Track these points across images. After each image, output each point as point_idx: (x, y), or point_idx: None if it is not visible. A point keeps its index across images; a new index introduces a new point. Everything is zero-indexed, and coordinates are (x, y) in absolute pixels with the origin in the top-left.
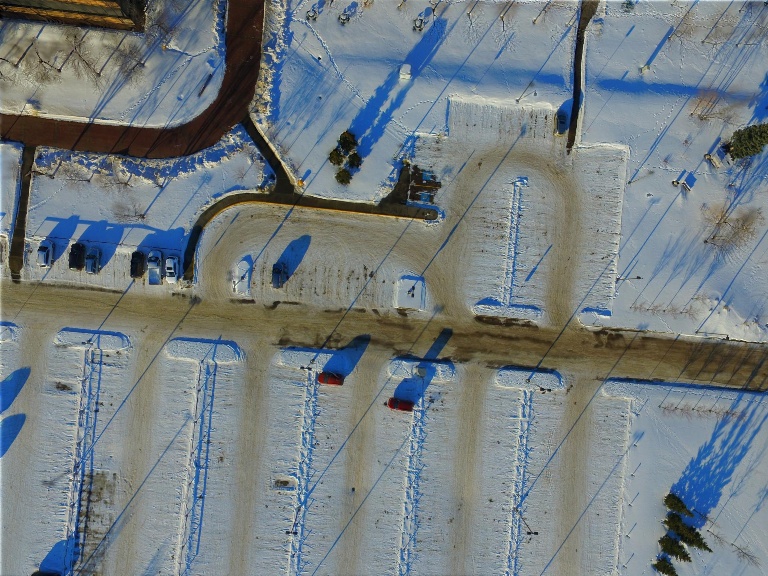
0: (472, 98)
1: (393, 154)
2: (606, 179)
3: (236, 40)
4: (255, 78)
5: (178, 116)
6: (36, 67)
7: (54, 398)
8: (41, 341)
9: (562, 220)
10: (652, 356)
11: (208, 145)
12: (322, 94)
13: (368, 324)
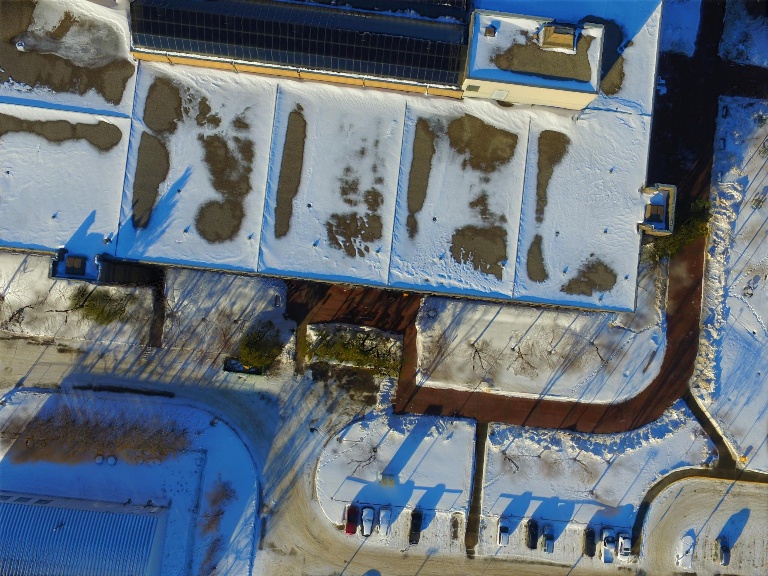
0: None
1: None
2: None
3: (676, 316)
4: (695, 353)
5: (624, 392)
6: (515, 360)
7: None
8: None
9: None
10: None
11: (651, 420)
12: (761, 370)
13: None
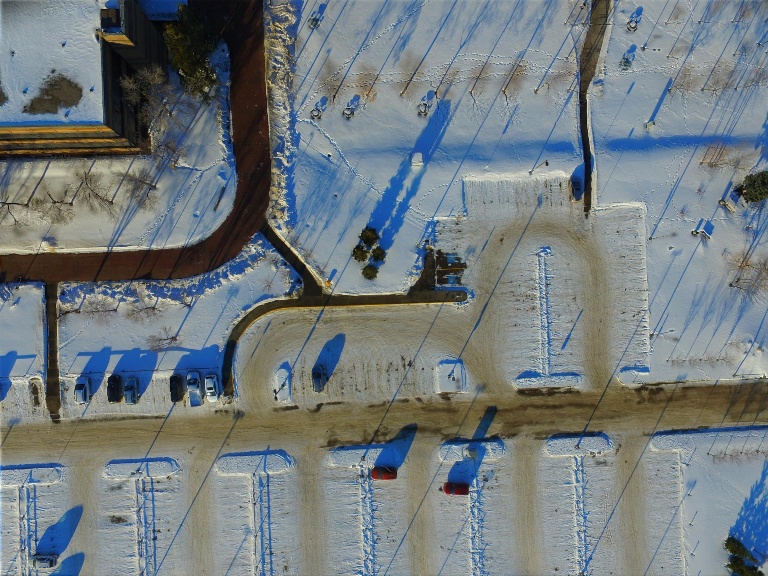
0: (486, 176)
1: (415, 242)
2: (627, 238)
3: (244, 149)
4: (268, 184)
5: (196, 233)
6: (50, 208)
7: (110, 533)
8: (89, 477)
9: (589, 284)
10: (694, 405)
11: (230, 258)
12: (337, 192)
13: (413, 413)
